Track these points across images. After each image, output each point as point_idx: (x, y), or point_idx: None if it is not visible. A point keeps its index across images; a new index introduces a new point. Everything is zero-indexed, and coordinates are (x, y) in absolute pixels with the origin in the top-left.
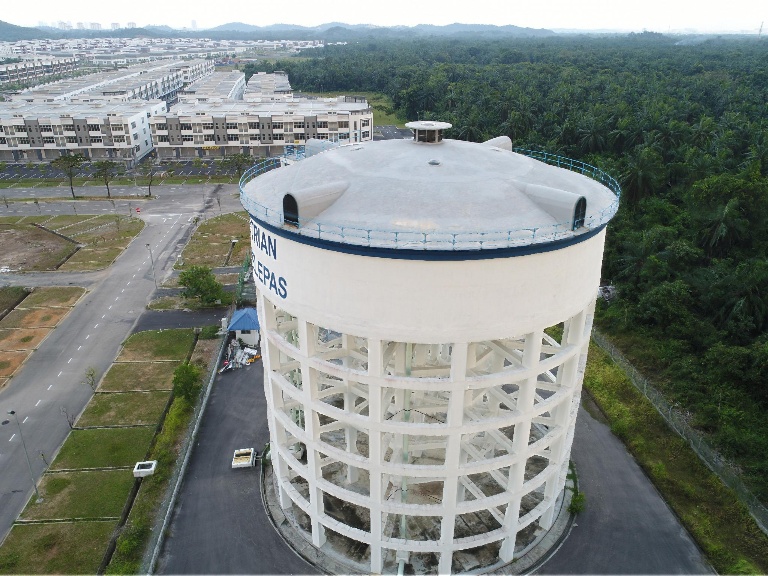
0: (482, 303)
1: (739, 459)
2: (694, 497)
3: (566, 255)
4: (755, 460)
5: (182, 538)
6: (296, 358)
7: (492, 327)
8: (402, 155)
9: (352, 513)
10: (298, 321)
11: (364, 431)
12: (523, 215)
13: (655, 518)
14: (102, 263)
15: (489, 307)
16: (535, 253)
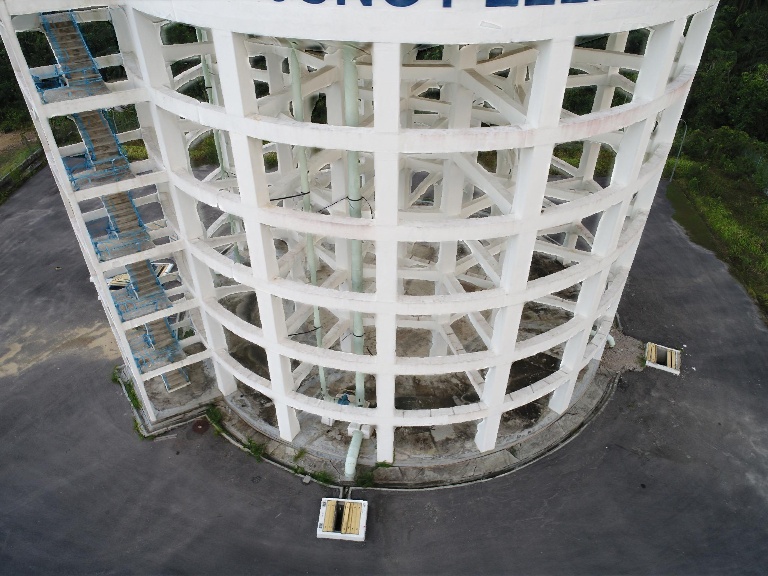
0: None
1: None
2: None
3: None
4: None
5: None
6: (643, 116)
7: None
8: None
9: None
10: (674, 27)
11: (471, 265)
12: None
13: None
14: None
15: None
16: None
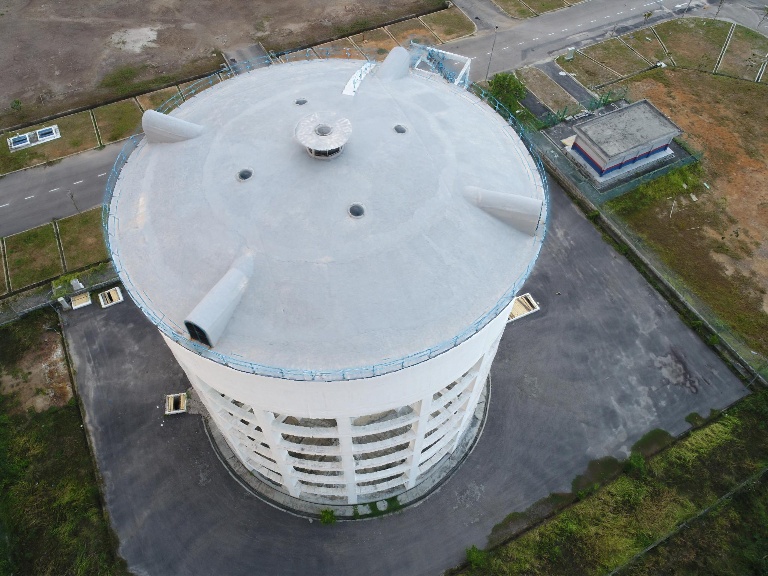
0: None
1: None
2: None
3: None
4: None
5: None
6: None
7: None
8: (262, 143)
9: None
10: None
11: None
12: (186, 285)
13: None
14: (527, 11)
15: None
16: None
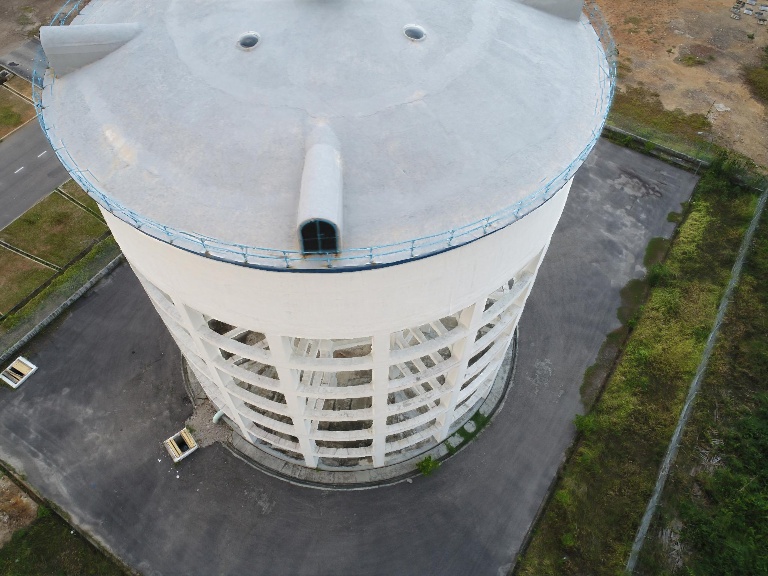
0: (179, 277)
1: (695, 553)
2: (569, 548)
3: (299, 278)
4: (708, 570)
5: (128, 271)
6: None
7: (201, 304)
8: (242, 3)
9: (245, 334)
10: None
11: None
12: (255, 196)
13: (498, 534)
14: None
15: (190, 285)
16: (226, 262)
